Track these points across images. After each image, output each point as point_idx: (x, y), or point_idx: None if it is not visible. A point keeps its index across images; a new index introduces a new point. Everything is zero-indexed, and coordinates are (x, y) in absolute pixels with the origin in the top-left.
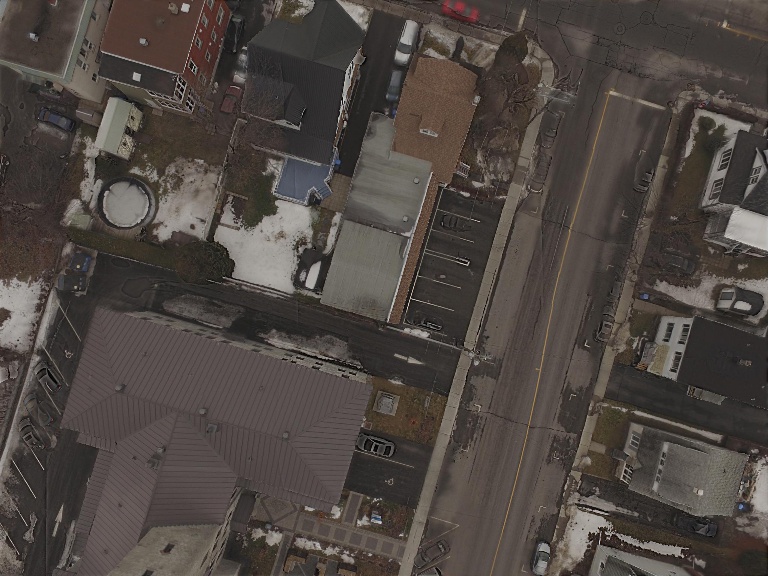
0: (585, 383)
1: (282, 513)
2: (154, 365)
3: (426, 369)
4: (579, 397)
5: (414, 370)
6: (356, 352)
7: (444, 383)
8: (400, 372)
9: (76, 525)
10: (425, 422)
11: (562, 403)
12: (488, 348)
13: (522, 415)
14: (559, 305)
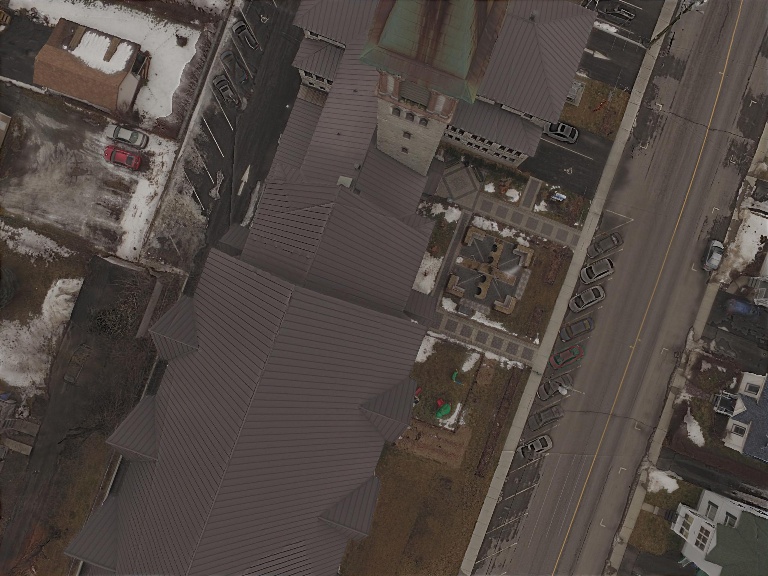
0: (766, 91)
1: (462, 191)
2: None
3: (611, 64)
4: (759, 104)
5: (599, 64)
6: None
7: (628, 80)
8: (586, 65)
9: (267, 177)
10: (607, 115)
11: (742, 109)
12: (673, 50)
13: (702, 116)
14: (746, 12)
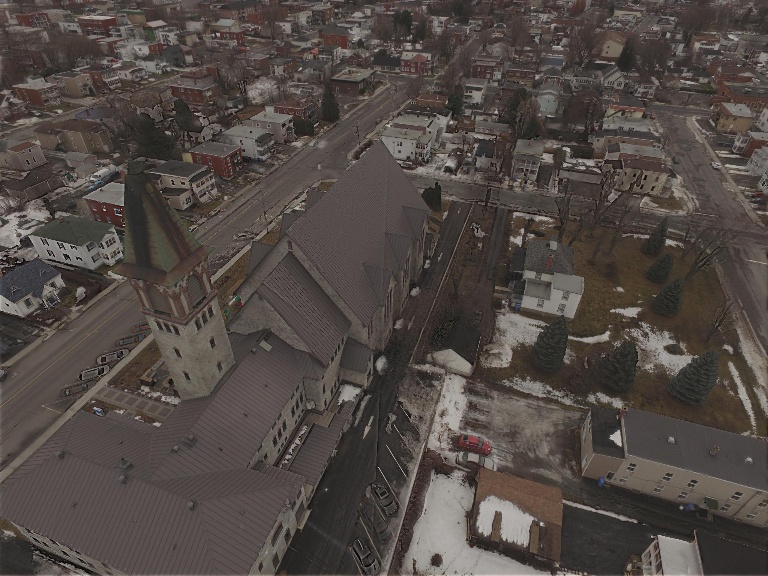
0: None
1: None
2: (166, 534)
3: None
4: None
5: None
6: (30, 571)
7: None
8: None
9: None
10: None
11: None
12: None
13: None
14: None
